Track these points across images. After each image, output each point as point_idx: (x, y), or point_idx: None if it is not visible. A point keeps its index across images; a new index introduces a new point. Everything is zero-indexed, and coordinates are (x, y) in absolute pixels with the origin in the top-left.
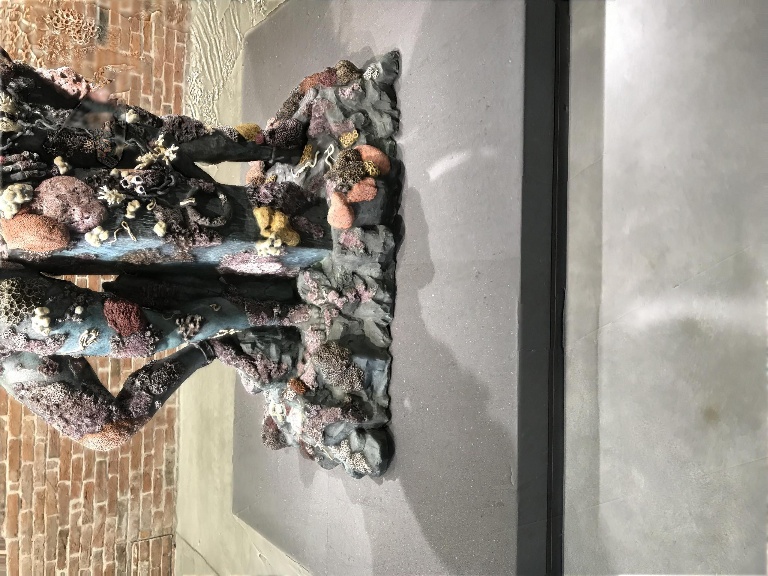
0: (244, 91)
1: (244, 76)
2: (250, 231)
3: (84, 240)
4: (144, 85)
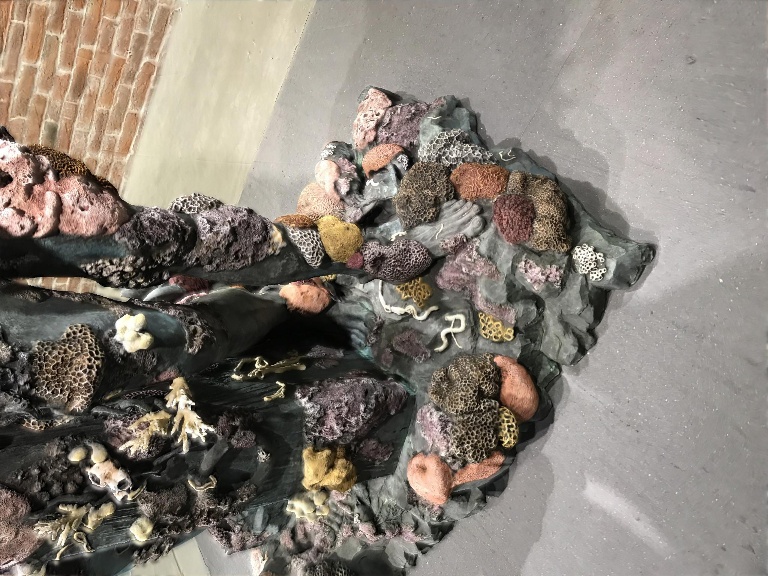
0: None
1: None
2: (288, 482)
3: None
4: None
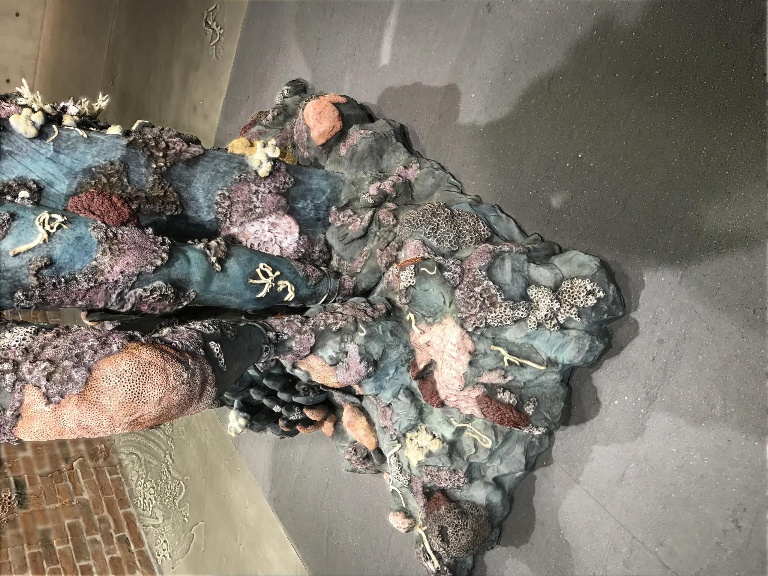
0: None
1: None
2: None
3: (10, 133)
4: (86, 527)
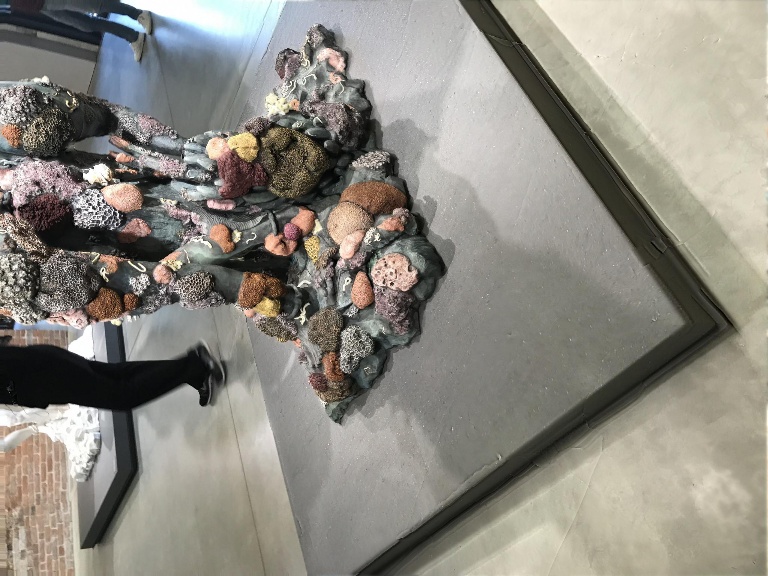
0: (602, 231)
1: (619, 255)
2: None
3: None
4: None
